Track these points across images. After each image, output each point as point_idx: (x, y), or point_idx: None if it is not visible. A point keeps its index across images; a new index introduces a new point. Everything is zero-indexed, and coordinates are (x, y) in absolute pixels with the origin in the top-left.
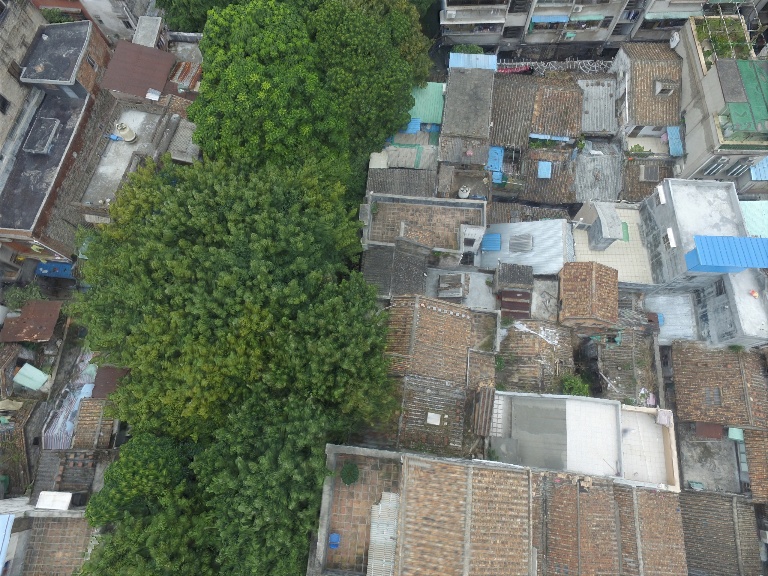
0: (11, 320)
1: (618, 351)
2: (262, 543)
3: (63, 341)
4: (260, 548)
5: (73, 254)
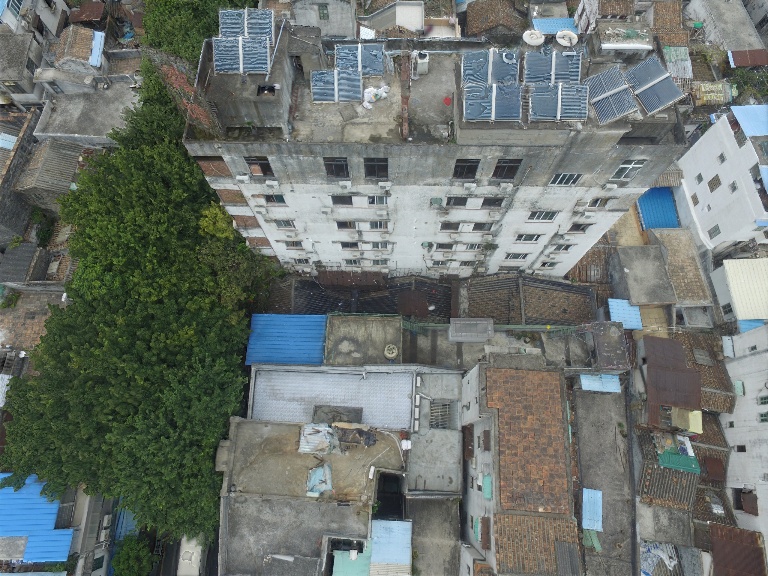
0: (74, 12)
1: (433, 3)
2: (232, 7)
3: (106, 28)
4: (231, 7)
5: (103, 0)
